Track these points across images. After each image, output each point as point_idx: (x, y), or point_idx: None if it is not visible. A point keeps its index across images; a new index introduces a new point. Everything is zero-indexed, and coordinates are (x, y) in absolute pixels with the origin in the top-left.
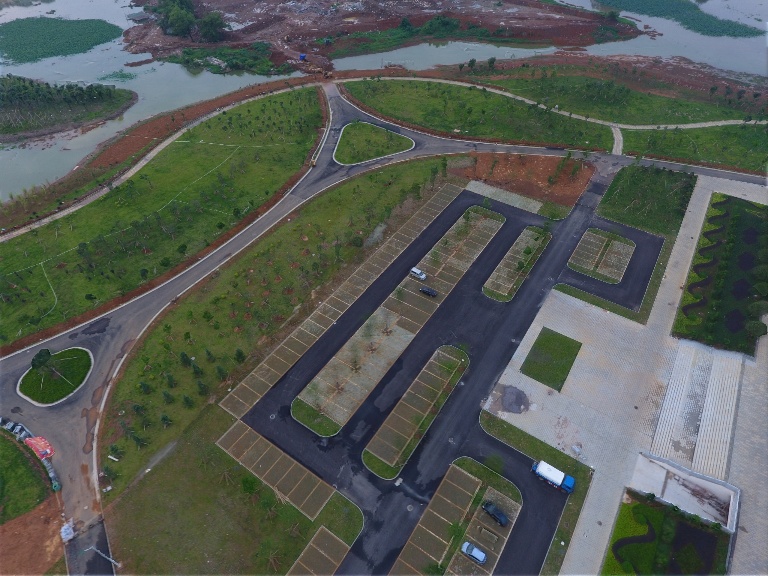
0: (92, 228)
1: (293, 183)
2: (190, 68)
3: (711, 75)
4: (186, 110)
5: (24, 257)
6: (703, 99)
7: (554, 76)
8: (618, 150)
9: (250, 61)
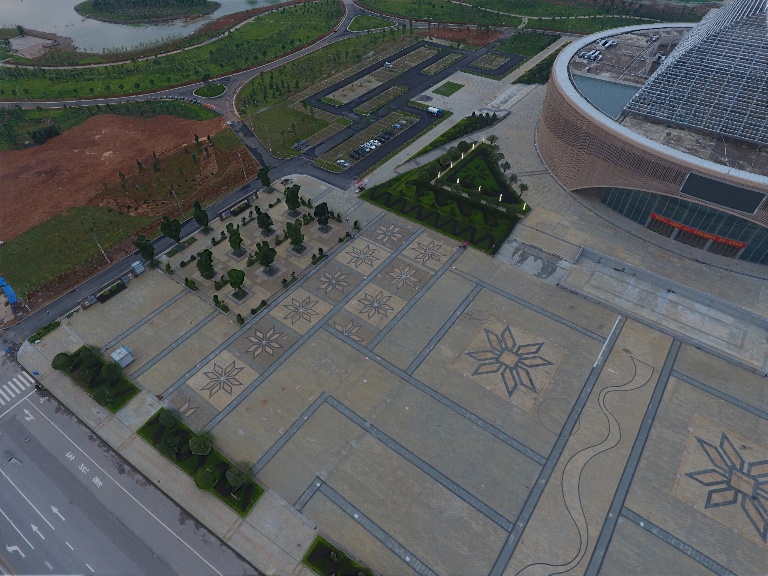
0: None
1: (323, 37)
2: None
3: None
4: (254, 10)
5: (178, 60)
6: (590, 6)
7: None
8: (521, 27)
9: None
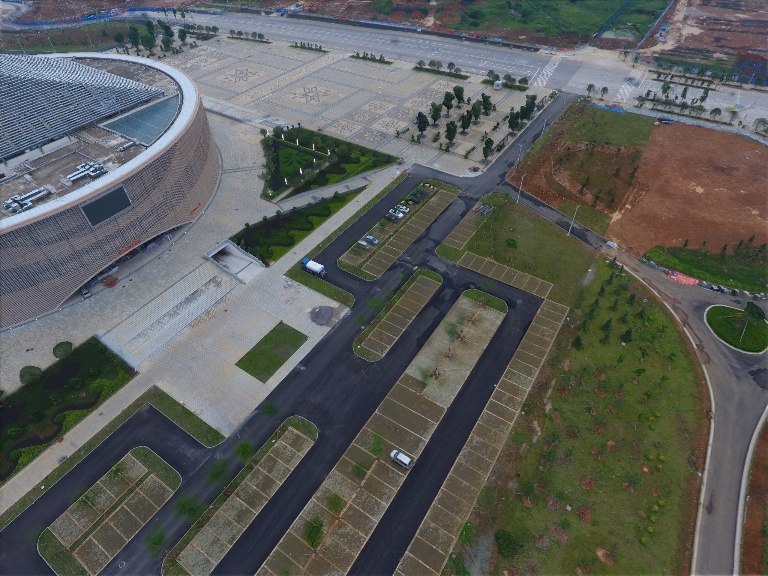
0: None
1: None
2: None
3: None
4: None
5: None
6: None
7: None
8: None
9: None
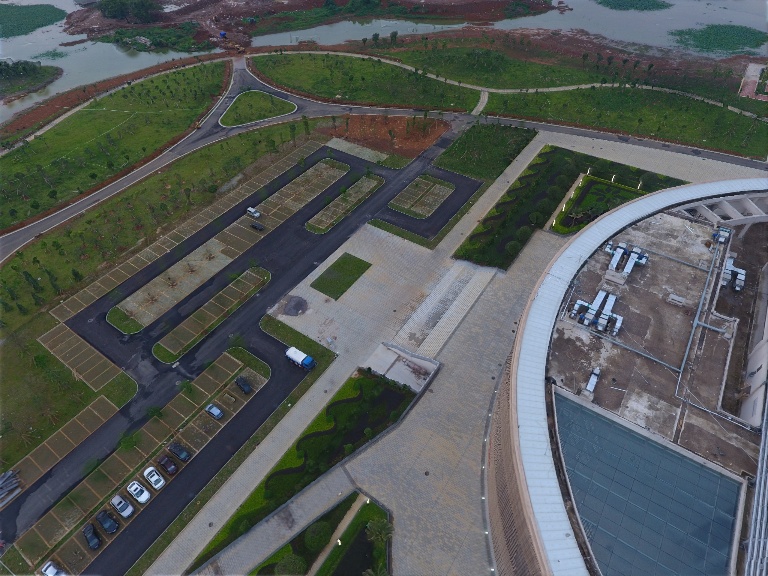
0: None
1: (174, 142)
2: (119, 47)
3: (600, 45)
4: (102, 83)
5: None
6: (578, 66)
7: (445, 47)
8: (478, 111)
9: (173, 39)
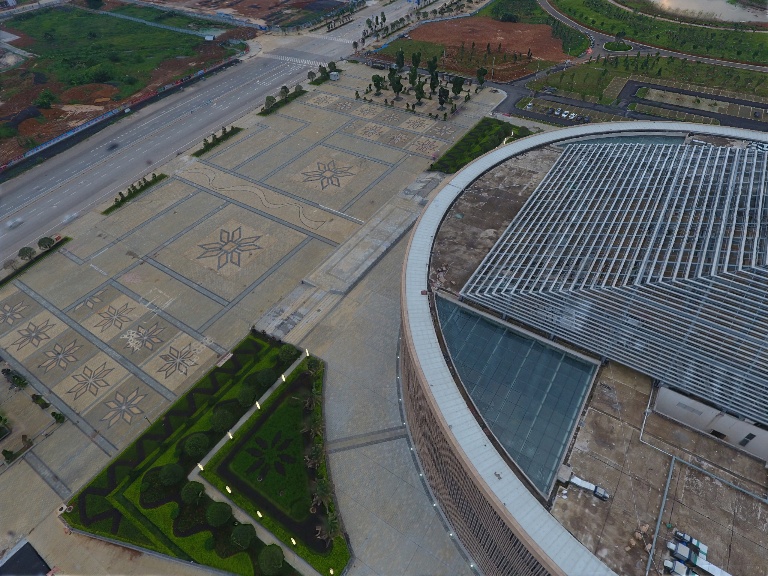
0: (701, 33)
1: None
2: None
3: None
4: None
5: (666, 27)
6: None
7: None
8: None
9: None
